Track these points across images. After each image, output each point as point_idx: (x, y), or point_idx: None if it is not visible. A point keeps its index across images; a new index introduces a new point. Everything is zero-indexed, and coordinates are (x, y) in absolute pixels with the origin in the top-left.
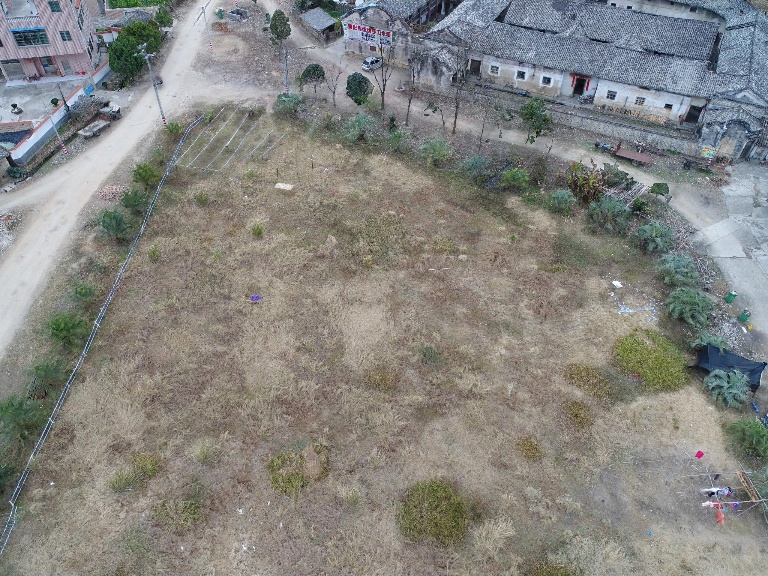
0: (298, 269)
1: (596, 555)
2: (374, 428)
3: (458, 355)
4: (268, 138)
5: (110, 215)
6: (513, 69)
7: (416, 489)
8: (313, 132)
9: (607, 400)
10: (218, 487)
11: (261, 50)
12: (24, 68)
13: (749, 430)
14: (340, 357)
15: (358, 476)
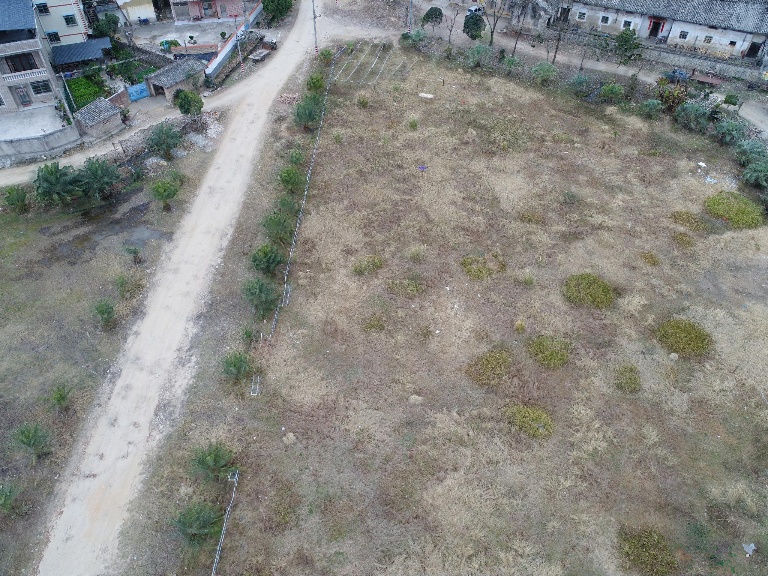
0: (451, 150)
1: (708, 316)
2: (533, 244)
3: (586, 204)
4: (401, 65)
5: (304, 107)
6: (598, 15)
7: (572, 278)
8: (436, 61)
9: (704, 232)
10: (428, 274)
11: (376, 2)
12: (190, 10)
13: None
14: (497, 204)
15: (528, 270)
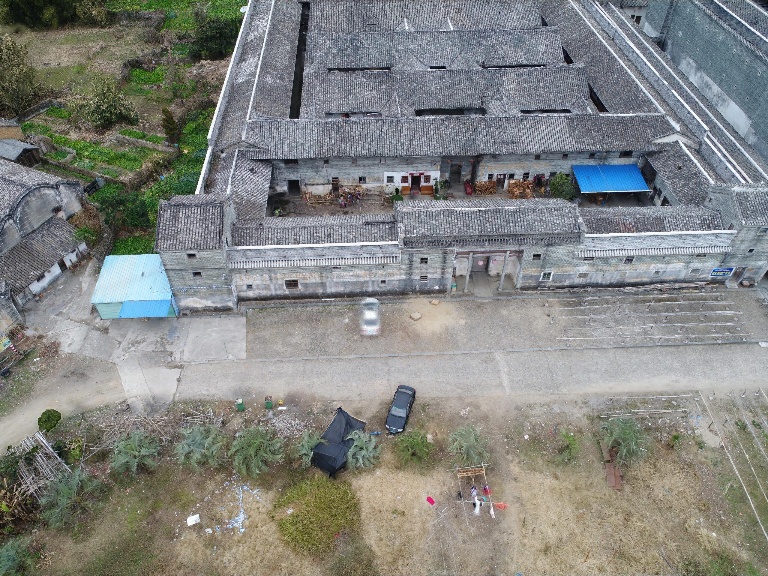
0: None
1: None
2: None
3: None
4: None
5: None
6: None
7: None
8: None
9: None
10: None
11: None
12: None
13: (416, 450)
14: None
15: None
